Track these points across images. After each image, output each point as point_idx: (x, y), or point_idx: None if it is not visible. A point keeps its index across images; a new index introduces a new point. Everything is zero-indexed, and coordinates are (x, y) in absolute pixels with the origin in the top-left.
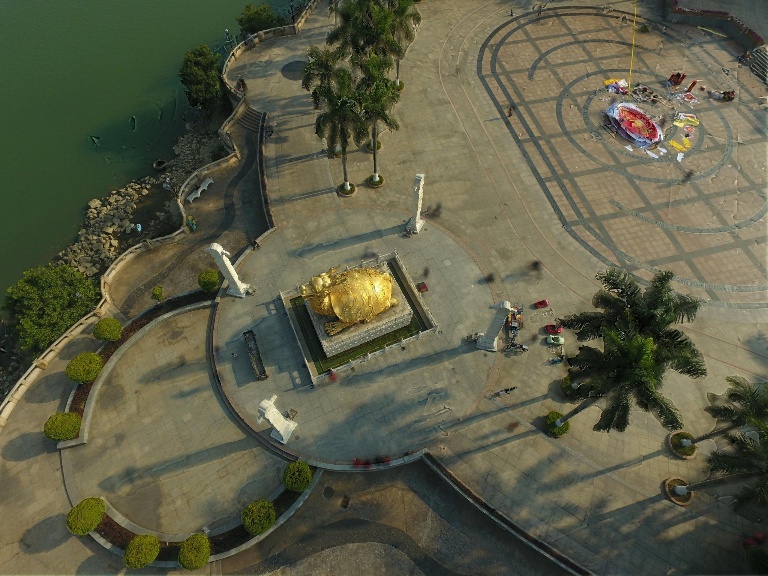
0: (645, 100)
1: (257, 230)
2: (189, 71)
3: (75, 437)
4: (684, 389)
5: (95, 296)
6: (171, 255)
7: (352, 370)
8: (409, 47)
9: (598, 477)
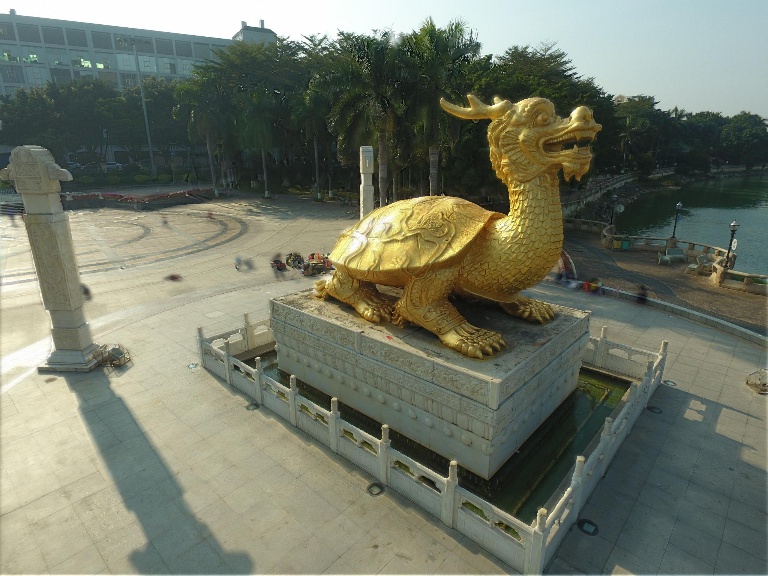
0: None
1: None
2: None
3: None
4: None
5: None
6: None
7: None
8: None
9: None
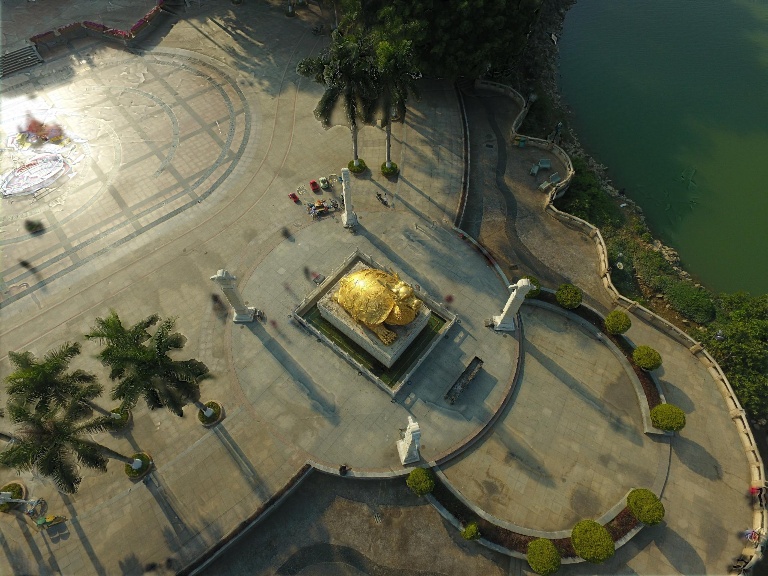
0: None
1: (312, 499)
2: None
3: None
4: None
5: None
6: None
7: None
8: None
9: (410, 145)
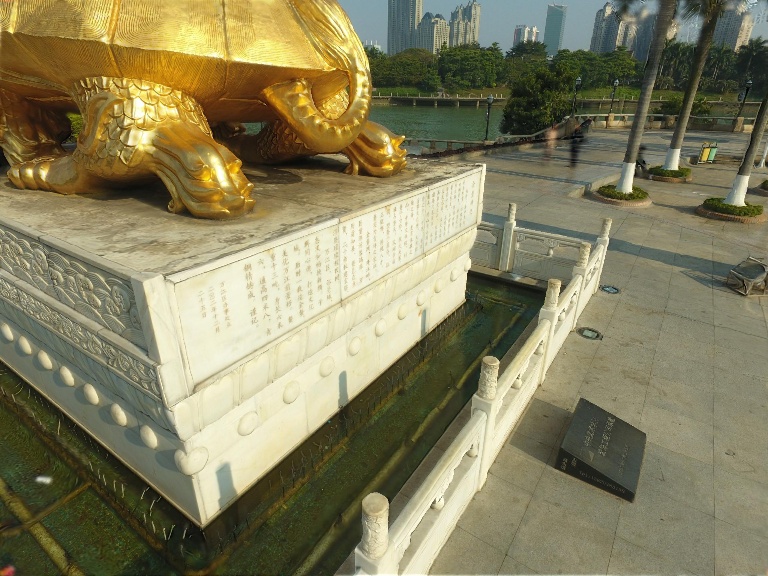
0: None
1: None
2: (523, 80)
3: None
4: None
5: None
6: None
7: None
8: None
9: None
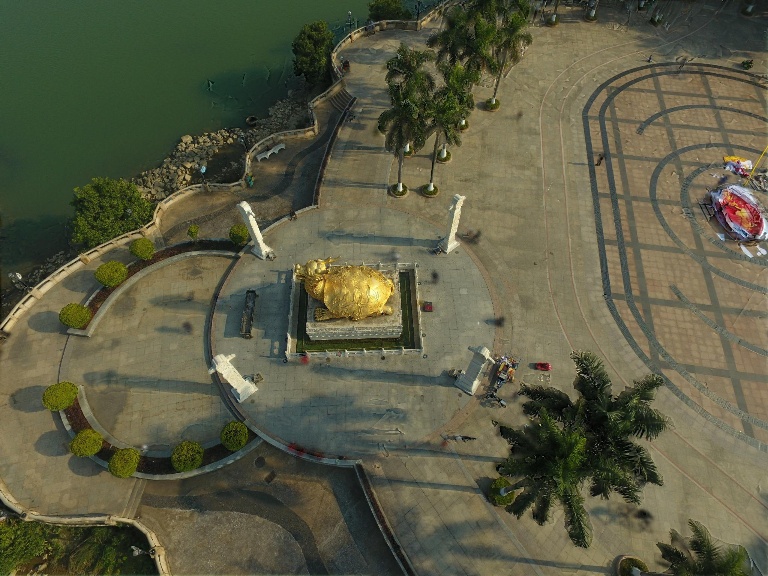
0: (766, 190)
1: (303, 203)
2: (301, 42)
3: (83, 328)
4: (663, 515)
5: (148, 217)
6: (223, 202)
7: (327, 360)
8: (523, 69)
9: (521, 564)
